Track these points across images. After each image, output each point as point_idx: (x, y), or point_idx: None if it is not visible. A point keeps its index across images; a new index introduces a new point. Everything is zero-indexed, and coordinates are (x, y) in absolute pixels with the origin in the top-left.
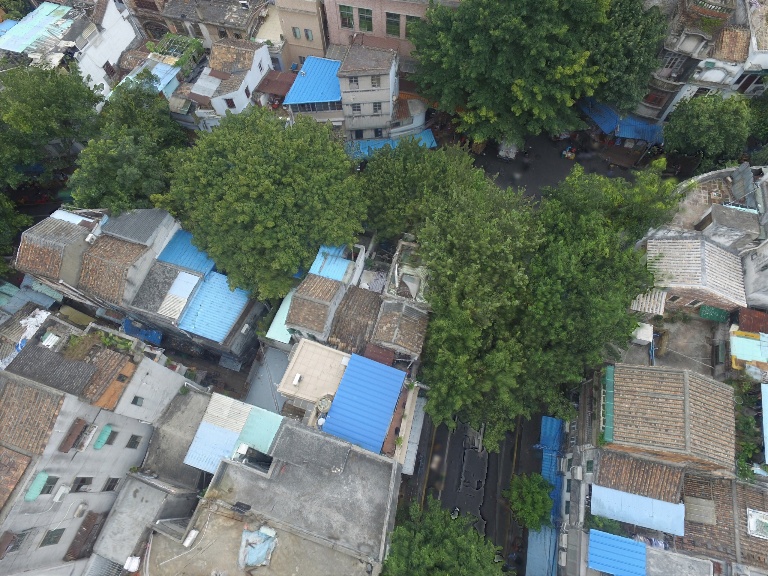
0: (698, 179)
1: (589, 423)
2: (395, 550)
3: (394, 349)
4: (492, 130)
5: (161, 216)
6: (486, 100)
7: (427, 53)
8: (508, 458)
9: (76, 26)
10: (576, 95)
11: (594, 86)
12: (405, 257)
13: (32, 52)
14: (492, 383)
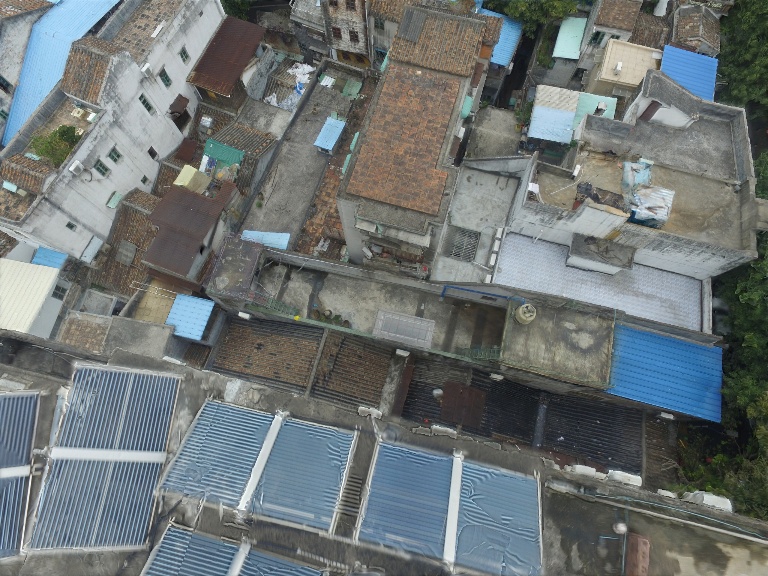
0: None
1: None
2: (762, 171)
3: (696, 47)
4: None
5: None
6: None
7: None
8: None
9: None
10: None
11: None
12: None
13: None
14: None
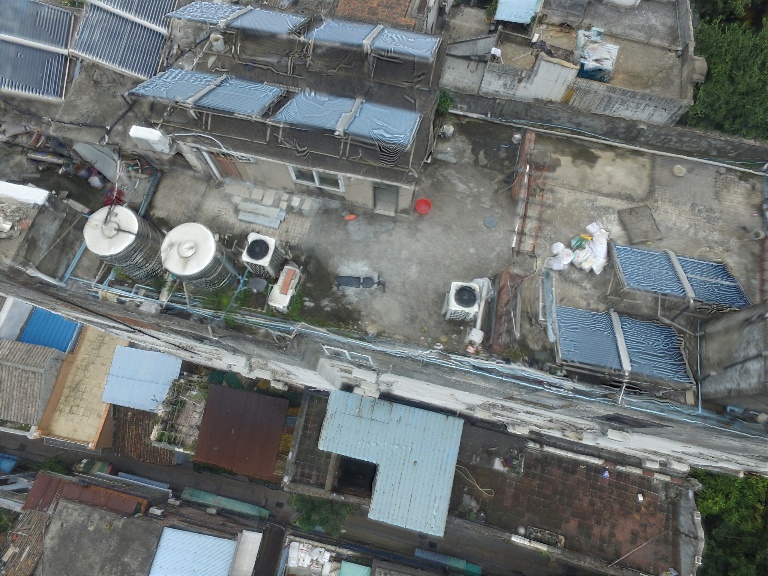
0: None
1: None
2: None
3: None
4: None
5: None
6: None
7: None
8: None
9: None
10: None
11: None
12: None
13: None
14: None
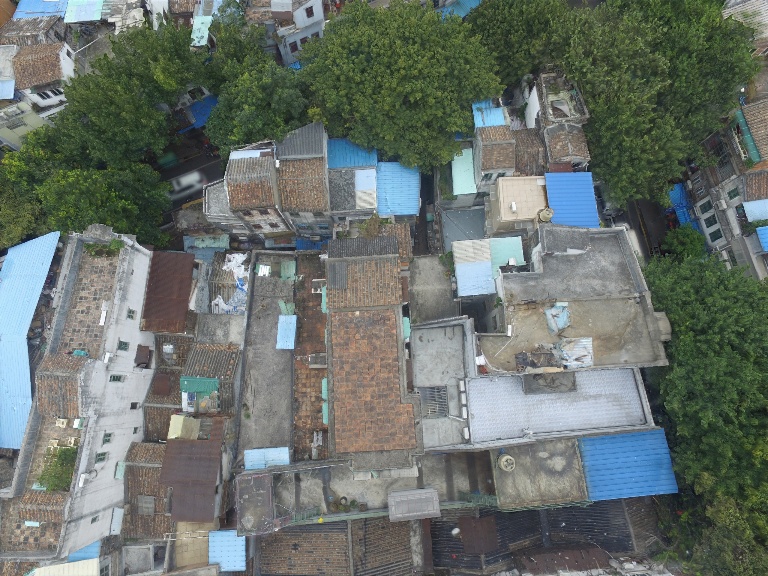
0: None
1: (720, 166)
2: (652, 281)
3: (570, 161)
4: None
5: (320, 128)
6: None
7: None
8: (639, 233)
9: None
10: None
11: None
12: (546, 88)
13: (110, 16)
14: (664, 152)
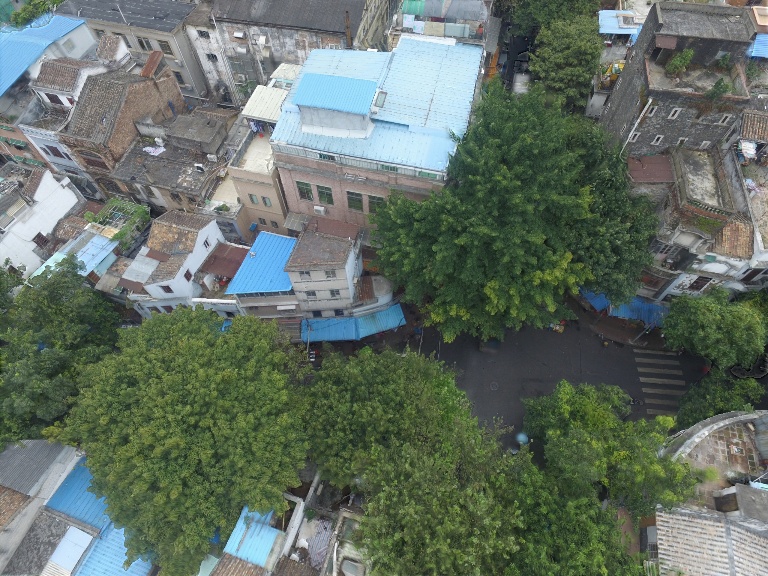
0: (713, 430)
1: None
2: None
3: None
4: (465, 323)
5: (55, 452)
6: (457, 294)
7: (387, 249)
8: None
9: (2, 203)
10: (560, 291)
11: (580, 282)
12: (348, 530)
13: None
14: None
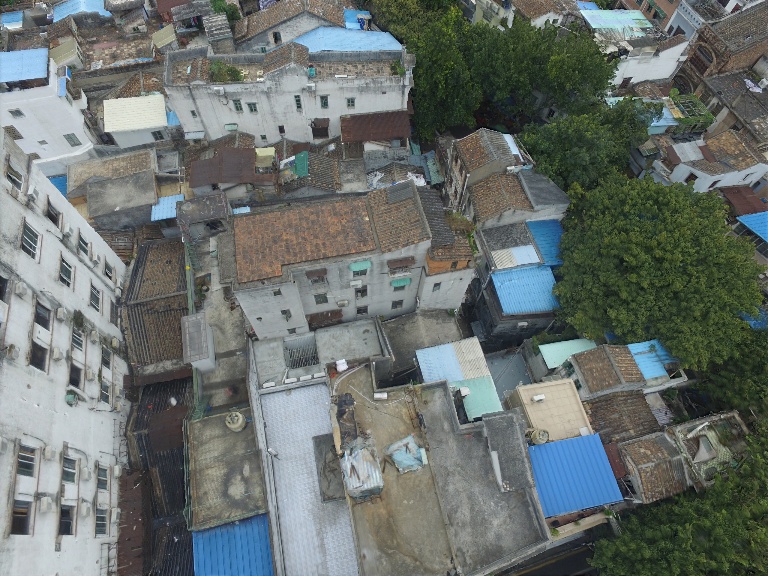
0: None
1: None
2: None
3: (630, 472)
4: None
5: (563, 200)
6: None
7: None
8: None
9: (645, 40)
10: None
11: None
12: (721, 426)
13: (600, 33)
14: None
